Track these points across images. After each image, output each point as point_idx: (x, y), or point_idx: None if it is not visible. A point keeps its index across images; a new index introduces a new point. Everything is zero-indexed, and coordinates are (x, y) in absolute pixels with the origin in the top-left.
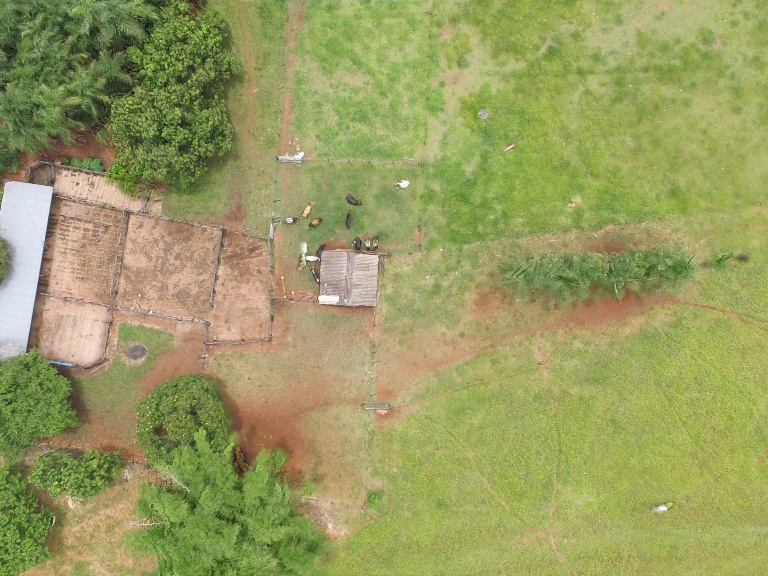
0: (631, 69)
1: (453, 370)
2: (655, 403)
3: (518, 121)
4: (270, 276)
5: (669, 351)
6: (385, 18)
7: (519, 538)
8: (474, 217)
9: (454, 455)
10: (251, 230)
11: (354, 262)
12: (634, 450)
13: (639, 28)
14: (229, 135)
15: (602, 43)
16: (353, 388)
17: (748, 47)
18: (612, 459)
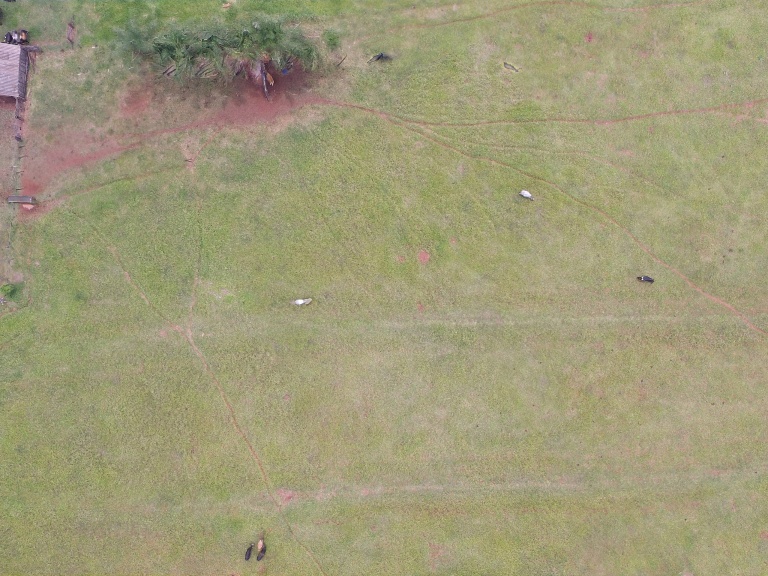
0: None
1: (100, 166)
2: (298, 200)
3: None
4: None
5: (316, 150)
6: None
7: (156, 331)
8: (127, 15)
9: (96, 249)
10: None
11: None
12: (275, 246)
13: None
14: None
15: None
16: None
17: None
18: (253, 255)
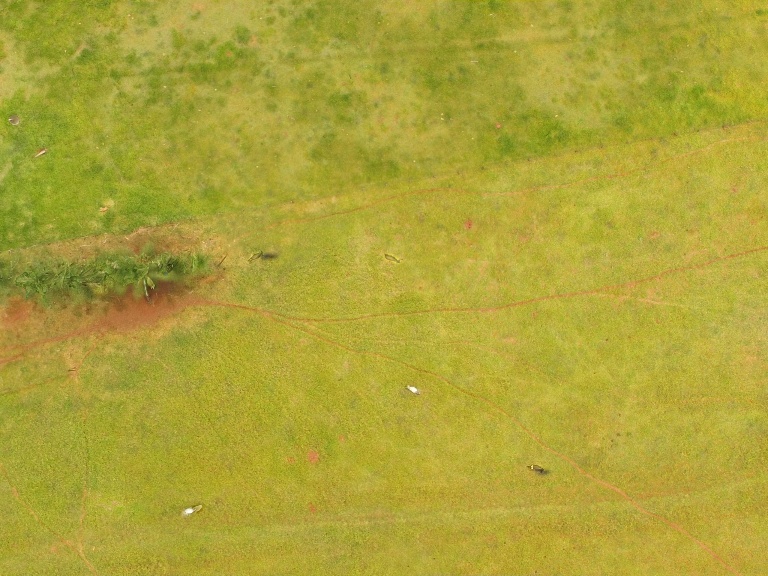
0: (165, 70)
1: None
2: (184, 406)
3: (50, 126)
4: None
5: (200, 353)
6: None
7: (47, 547)
8: (3, 225)
9: None
10: None
11: None
12: (163, 454)
13: (174, 28)
14: None
15: (137, 45)
16: None
17: (284, 44)
18: (141, 464)
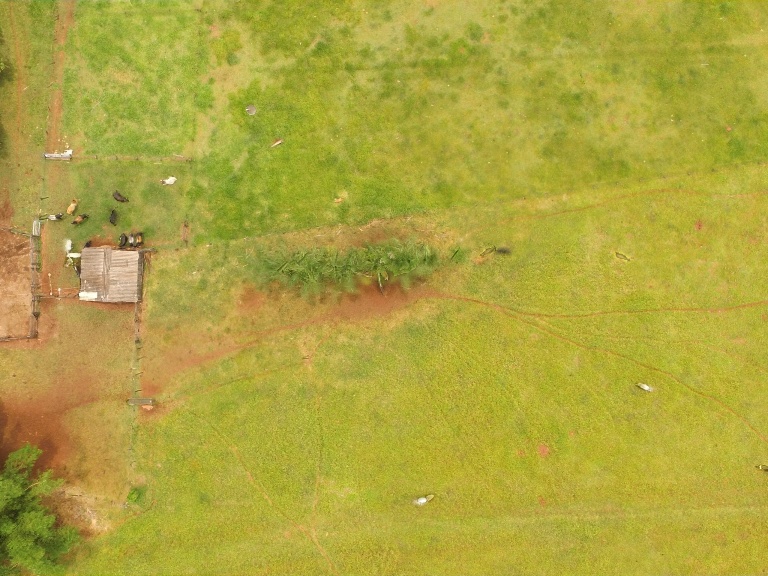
0: (399, 65)
1: (218, 365)
2: (417, 396)
3: (286, 117)
4: (37, 273)
5: (432, 344)
6: (155, 15)
7: (281, 532)
8: (240, 213)
9: (218, 450)
10: (19, 227)
11: (111, 258)
12: (396, 443)
13: (408, 24)
14: None
15: (371, 39)
16: (118, 384)
17: (516, 42)
18: (374, 452)
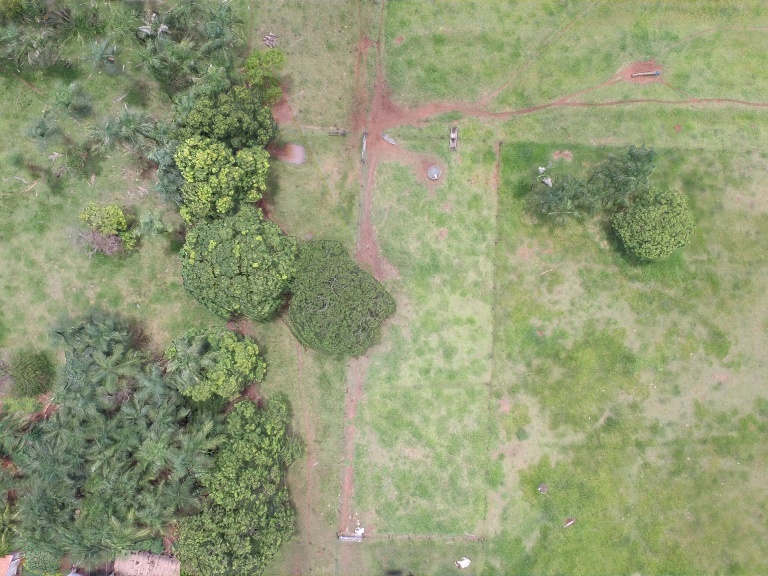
0: (689, 442)
1: None
2: None
3: (577, 496)
4: None
5: None
6: (444, 389)
7: None
8: None
9: None
10: None
11: None
12: None
13: (696, 399)
14: (292, 527)
15: (660, 414)
16: None
17: None
18: None
